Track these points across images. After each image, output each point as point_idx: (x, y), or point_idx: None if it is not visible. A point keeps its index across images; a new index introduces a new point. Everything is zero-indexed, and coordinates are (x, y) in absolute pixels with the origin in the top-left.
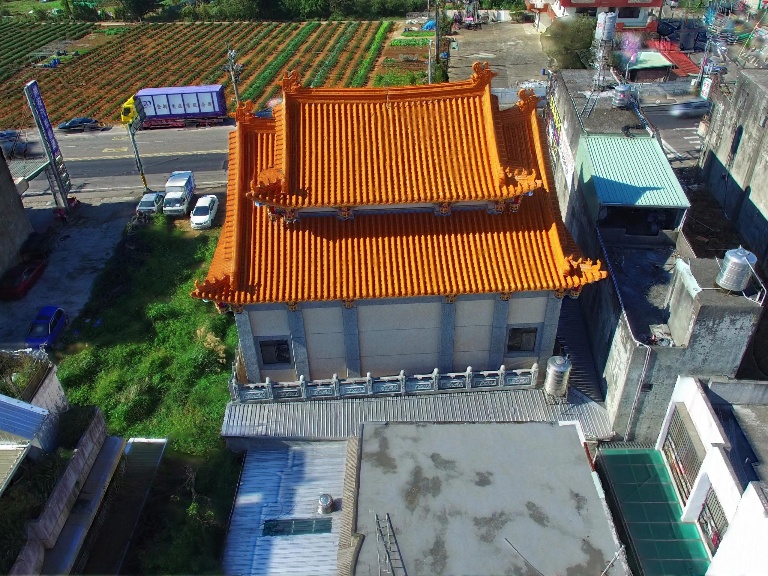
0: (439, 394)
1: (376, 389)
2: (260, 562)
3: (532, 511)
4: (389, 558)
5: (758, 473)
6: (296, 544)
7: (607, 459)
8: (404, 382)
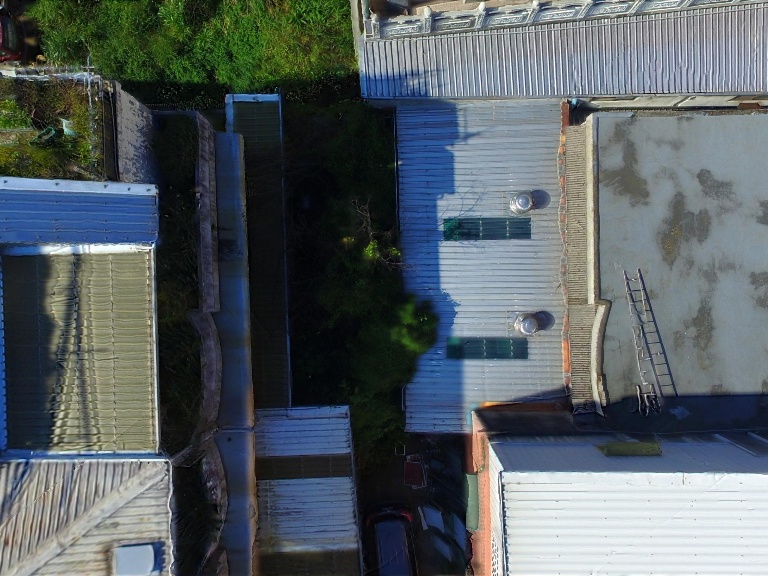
0: (684, 11)
1: (591, 11)
2: (448, 275)
3: None
4: (643, 332)
5: None
6: (489, 253)
7: None
8: (641, 2)
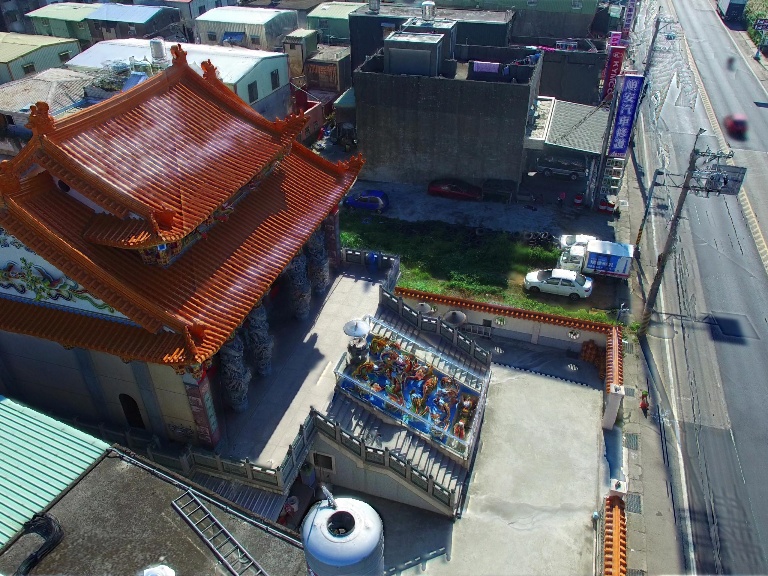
0: None
1: None
2: None
3: None
4: None
5: None
6: None
7: None
8: None
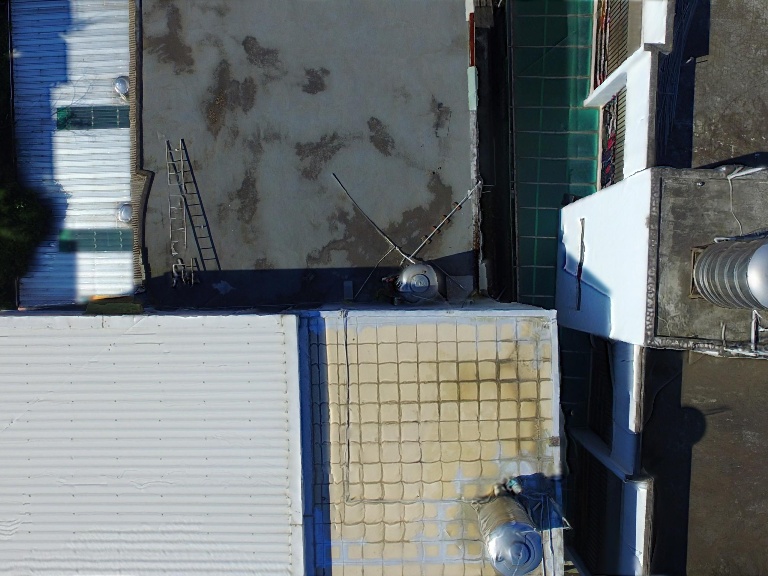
0: None
1: None
2: (61, 165)
3: (374, 132)
4: (185, 204)
5: (698, 75)
6: (99, 142)
7: (516, 5)
8: None
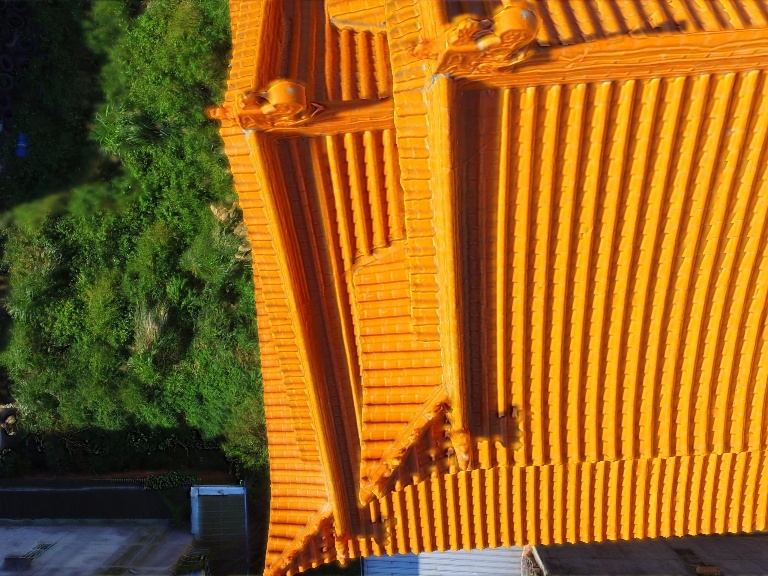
0: None
1: None
2: None
3: None
4: None
5: None
6: None
7: None
8: None
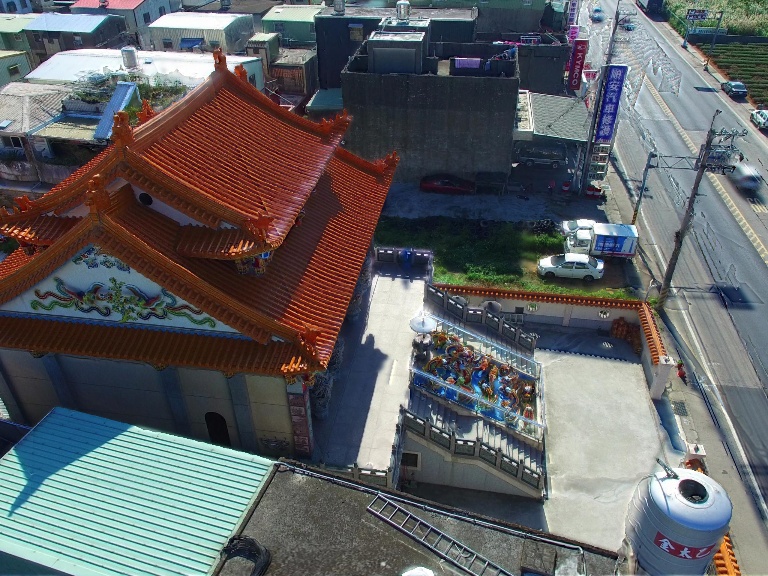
0: None
1: None
2: None
3: None
4: None
5: None
6: None
7: None
8: None
